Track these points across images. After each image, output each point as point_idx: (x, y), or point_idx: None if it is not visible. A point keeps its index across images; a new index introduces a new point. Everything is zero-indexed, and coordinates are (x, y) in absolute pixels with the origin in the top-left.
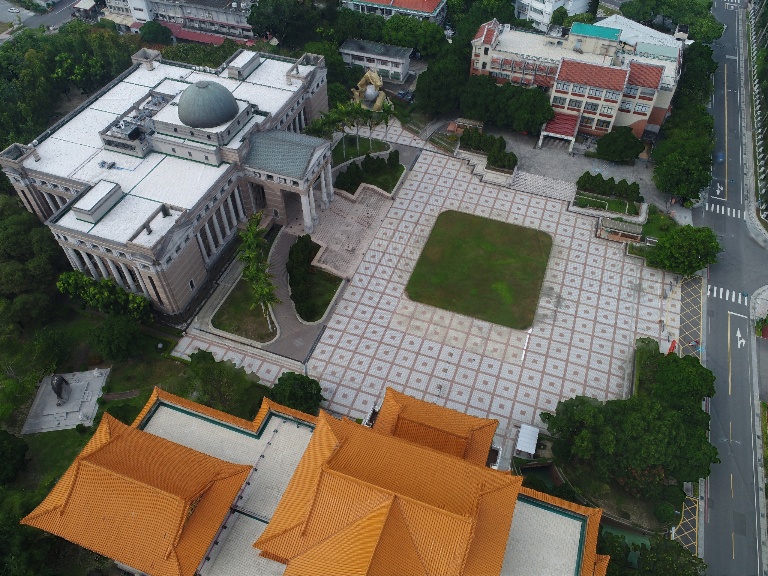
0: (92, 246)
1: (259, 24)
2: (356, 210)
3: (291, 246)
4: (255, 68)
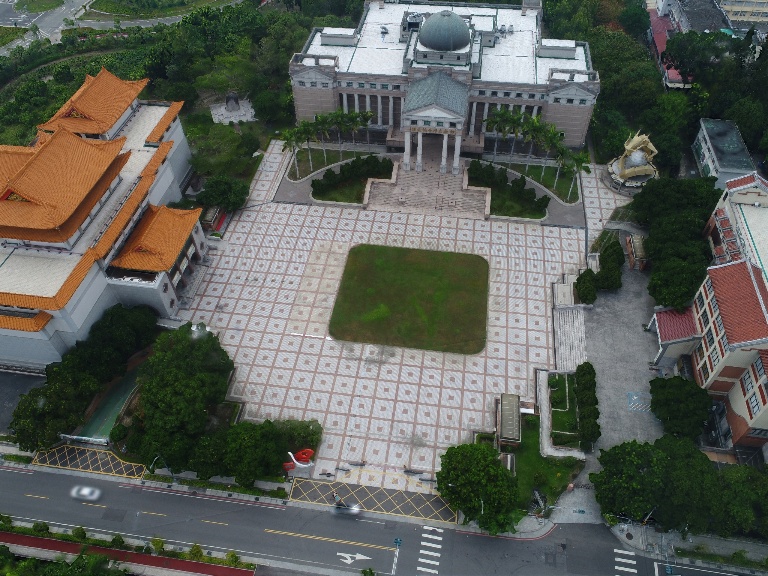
0: None
1: None
2: None
3: None
4: (562, 57)
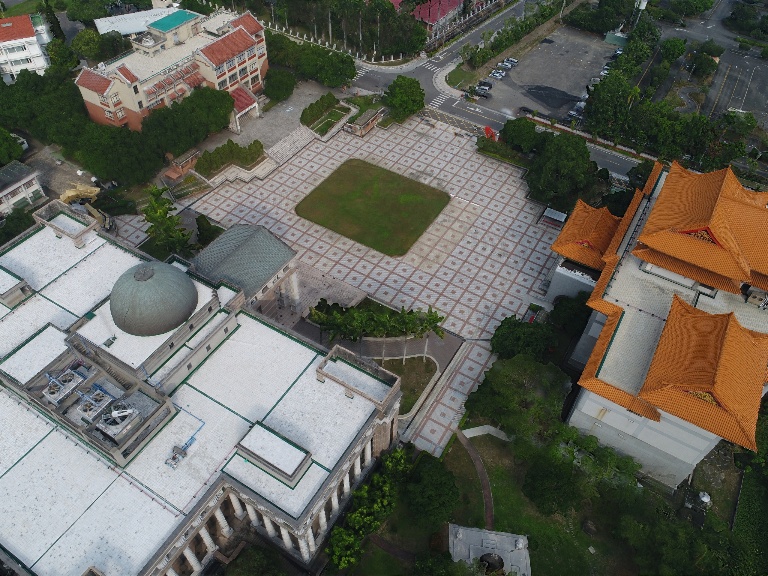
0: None
1: None
2: None
3: (312, 328)
4: None
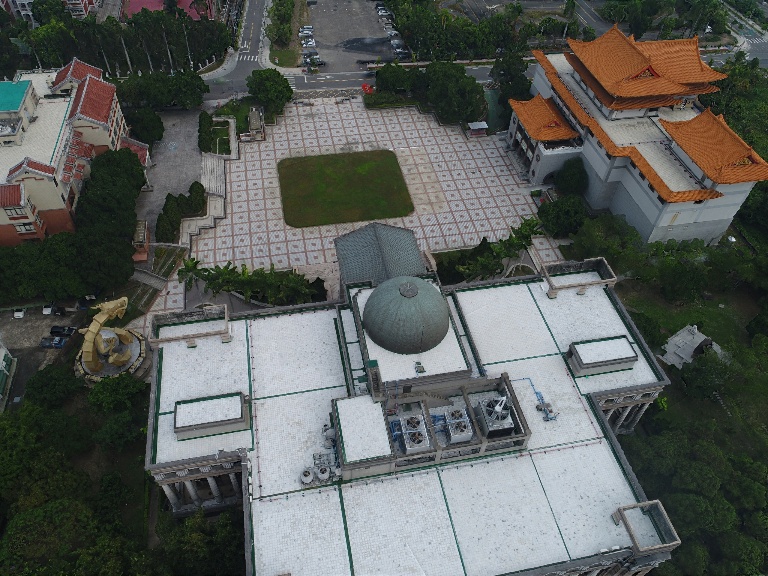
0: None
1: None
2: None
3: None
4: None
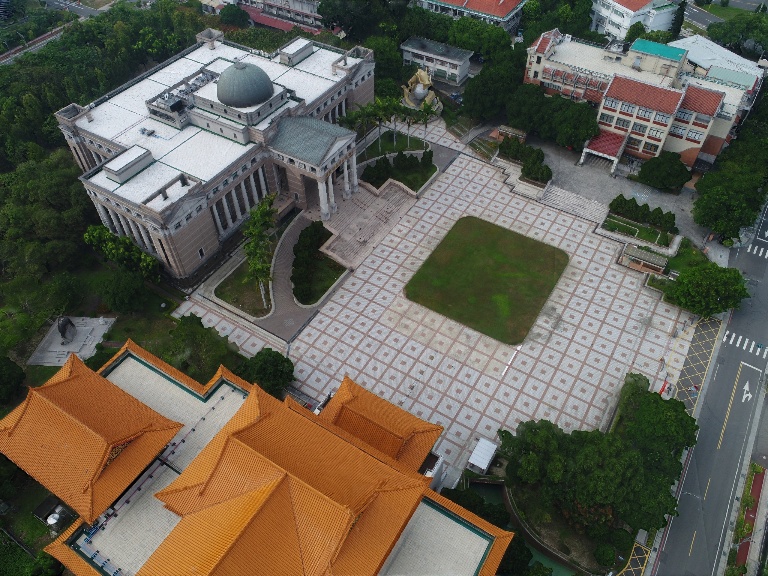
0: (116, 204)
1: (326, 15)
2: (377, 204)
3: None
4: (307, 56)
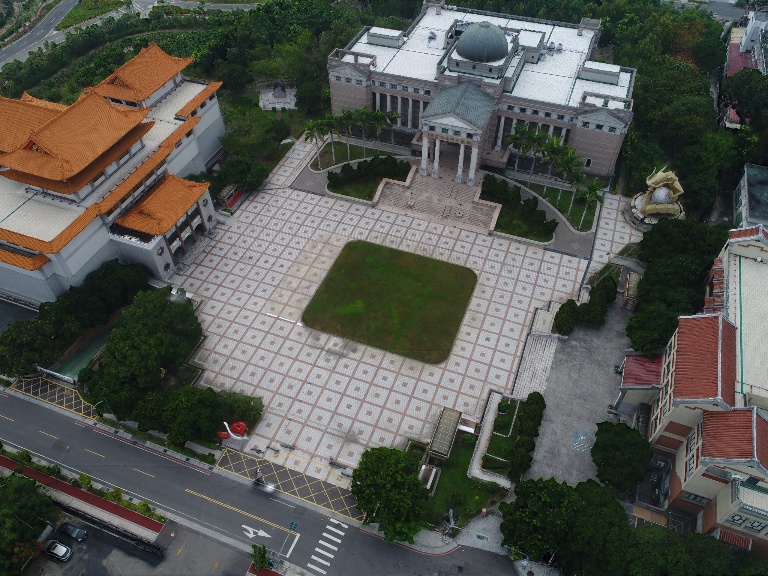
0: None
1: None
2: (462, 205)
3: None
4: (604, 82)
